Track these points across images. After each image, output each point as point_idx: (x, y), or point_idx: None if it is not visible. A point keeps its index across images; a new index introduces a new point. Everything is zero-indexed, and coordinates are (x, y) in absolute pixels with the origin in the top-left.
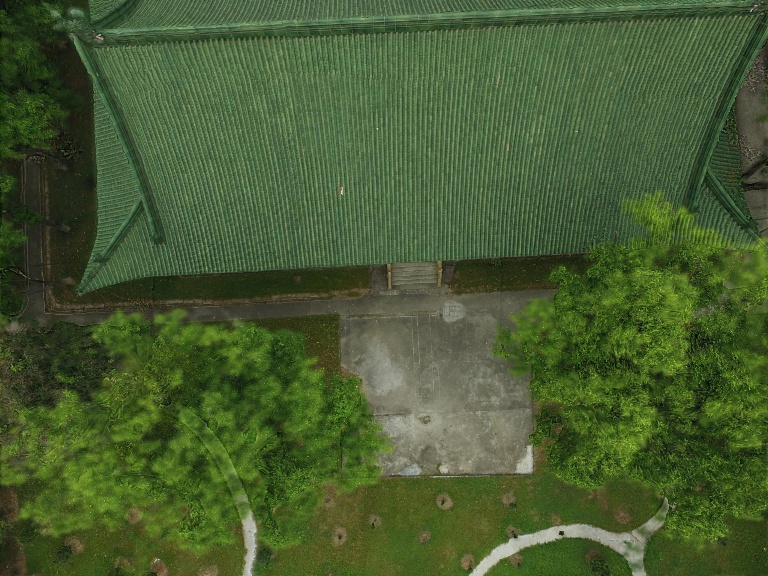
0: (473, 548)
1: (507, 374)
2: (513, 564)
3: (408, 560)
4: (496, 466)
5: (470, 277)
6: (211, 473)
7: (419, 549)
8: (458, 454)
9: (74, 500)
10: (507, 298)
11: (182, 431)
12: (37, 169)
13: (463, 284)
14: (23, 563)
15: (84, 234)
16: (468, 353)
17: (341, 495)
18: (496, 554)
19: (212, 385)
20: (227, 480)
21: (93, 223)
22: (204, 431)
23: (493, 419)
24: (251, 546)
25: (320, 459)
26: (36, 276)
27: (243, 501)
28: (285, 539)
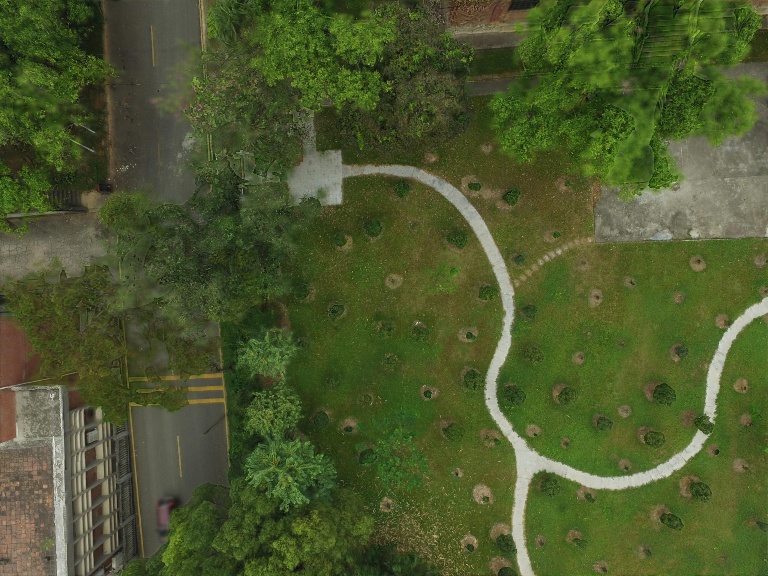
0: (727, 308)
1: (754, 142)
2: (767, 323)
3: (664, 319)
4: (746, 230)
5: (715, 49)
6: (469, 239)
7: (674, 309)
8: (708, 219)
9: (336, 267)
10: (751, 69)
11: (438, 200)
12: None
13: (708, 56)
14: (288, 328)
15: (336, 15)
16: (715, 122)
17: (596, 258)
18: (750, 313)
19: (466, 156)
20: (484, 246)
21: (344, 4)
22: (460, 200)
23: (742, 185)
24: (509, 308)
25: (574, 224)
26: None
27: (500, 266)
28: (673, 177)
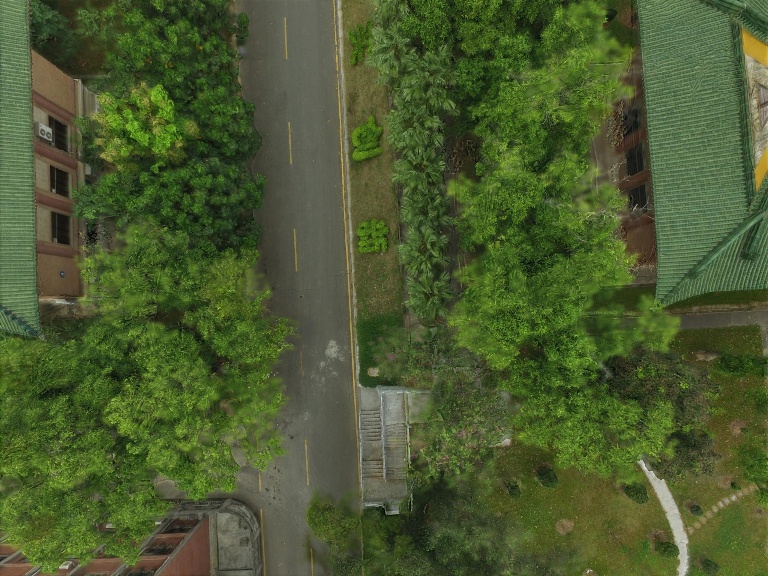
0: None
1: None
2: None
3: None
4: None
5: None
6: None
7: None
8: None
9: (505, 511)
10: None
11: None
12: (452, 180)
13: None
14: None
15: None
16: None
17: None
18: None
19: None
20: (657, 491)
21: None
22: None
23: None
24: (683, 557)
25: None
26: (455, 287)
27: (673, 512)
28: None
